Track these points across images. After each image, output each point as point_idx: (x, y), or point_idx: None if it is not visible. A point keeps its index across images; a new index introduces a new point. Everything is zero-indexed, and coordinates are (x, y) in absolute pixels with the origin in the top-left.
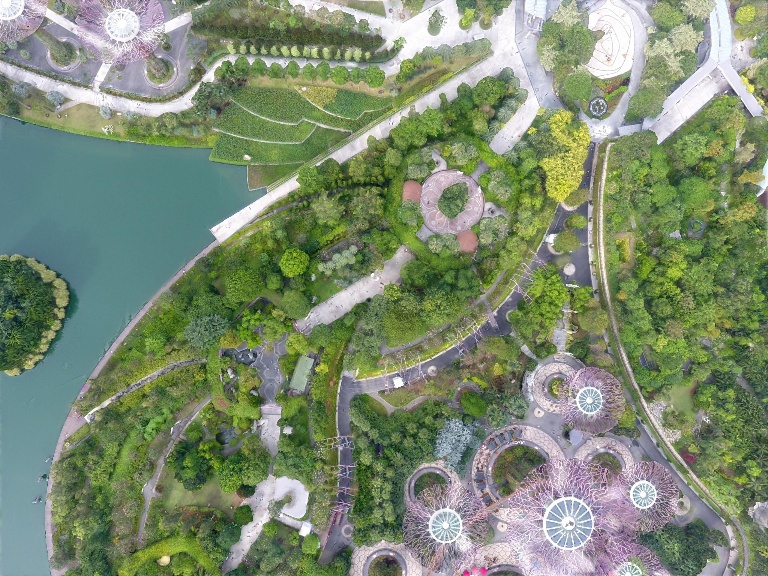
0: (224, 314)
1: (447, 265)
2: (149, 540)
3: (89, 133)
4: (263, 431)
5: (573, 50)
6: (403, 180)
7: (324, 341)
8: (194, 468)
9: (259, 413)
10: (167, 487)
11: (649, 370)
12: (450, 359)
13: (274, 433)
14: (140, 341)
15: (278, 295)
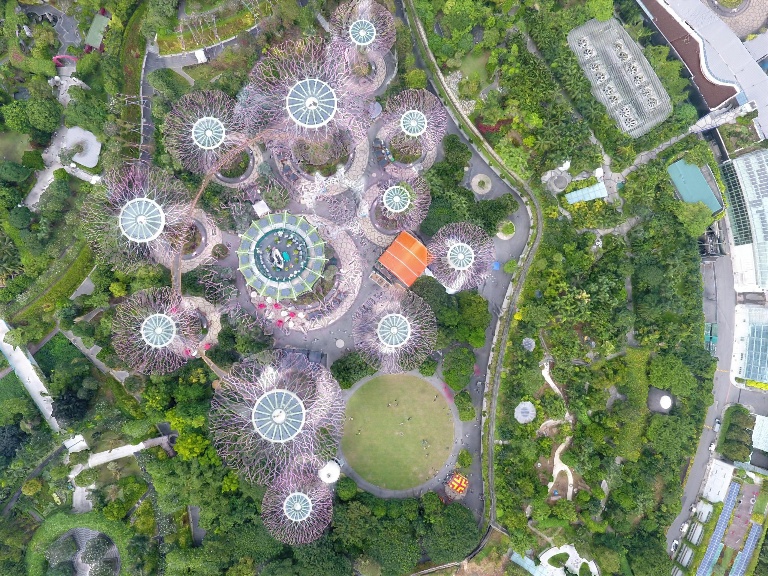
0: None
1: None
2: None
3: None
4: (61, 91)
5: None
6: None
7: None
8: None
9: (55, 69)
10: None
11: None
12: None
13: None
14: None
15: None
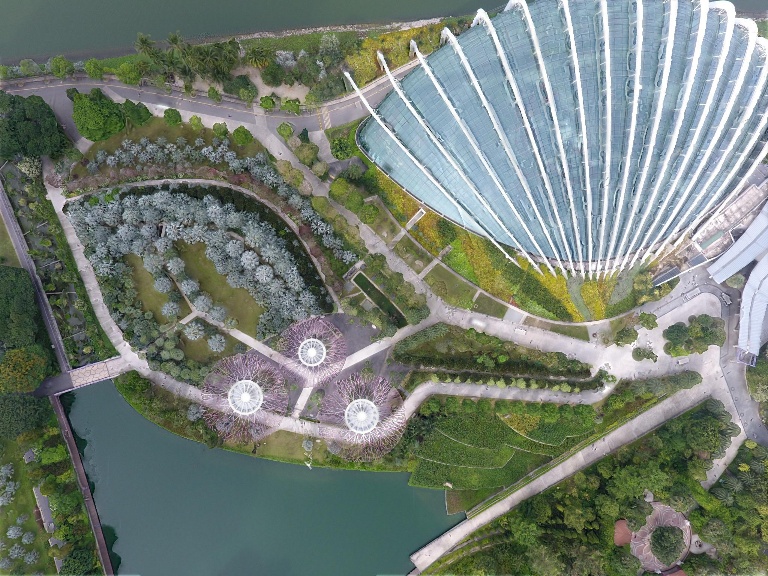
0: None
1: None
2: None
3: (288, 461)
4: None
5: None
6: (614, 521)
7: None
8: None
9: None
10: None
11: None
12: None
13: None
14: None
15: None
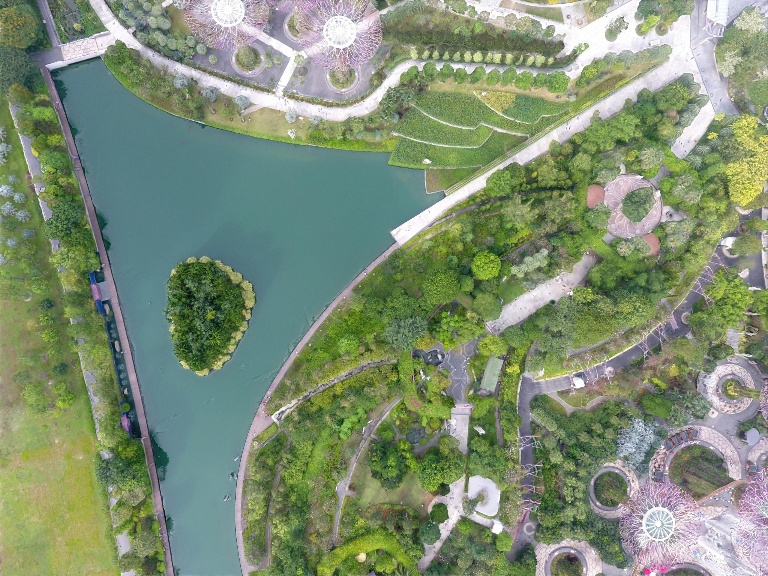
0: (422, 316)
1: (632, 268)
2: (344, 537)
3: (272, 137)
4: (452, 431)
5: (758, 56)
6: (587, 184)
7: (518, 342)
8: (397, 467)
9: (450, 413)
10: (360, 485)
11: None
12: (627, 360)
13: (462, 433)
14: (325, 342)
15: (467, 297)
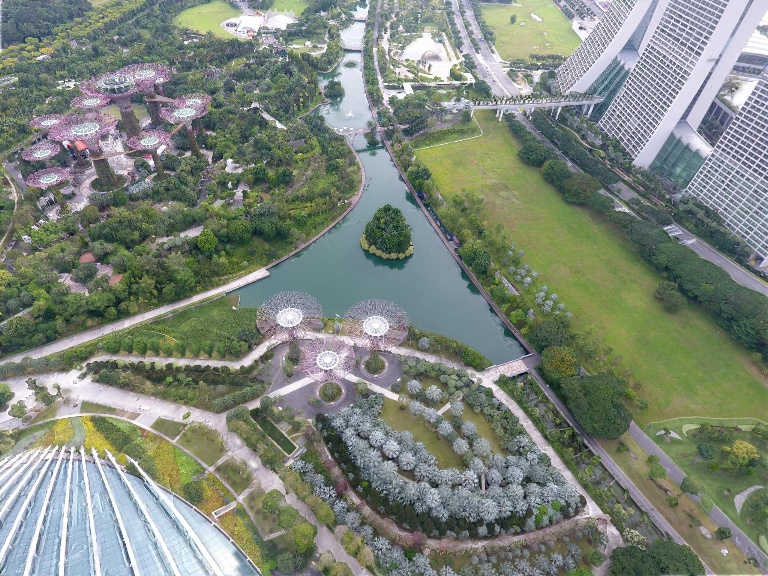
0: (254, 218)
1: None
2: None
3: None
4: None
5: None
6: None
7: None
8: None
9: None
10: (299, 175)
11: (3, 207)
12: None
13: None
14: (317, 227)
15: None
